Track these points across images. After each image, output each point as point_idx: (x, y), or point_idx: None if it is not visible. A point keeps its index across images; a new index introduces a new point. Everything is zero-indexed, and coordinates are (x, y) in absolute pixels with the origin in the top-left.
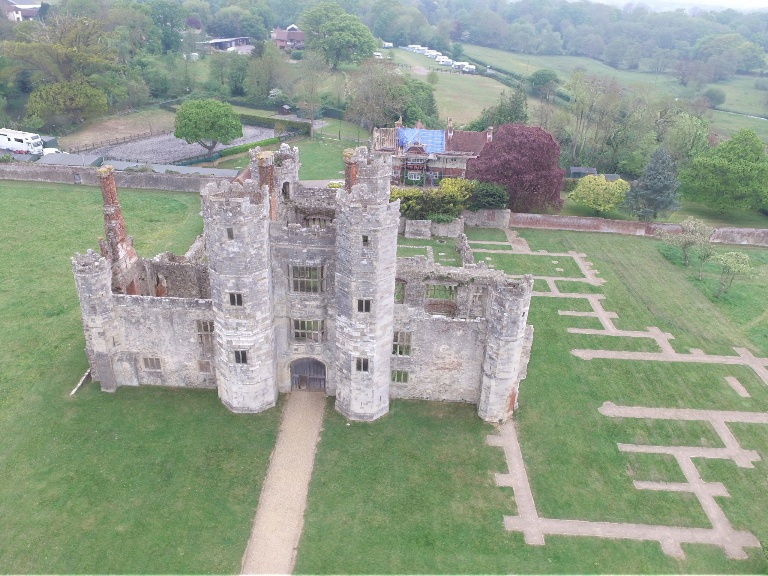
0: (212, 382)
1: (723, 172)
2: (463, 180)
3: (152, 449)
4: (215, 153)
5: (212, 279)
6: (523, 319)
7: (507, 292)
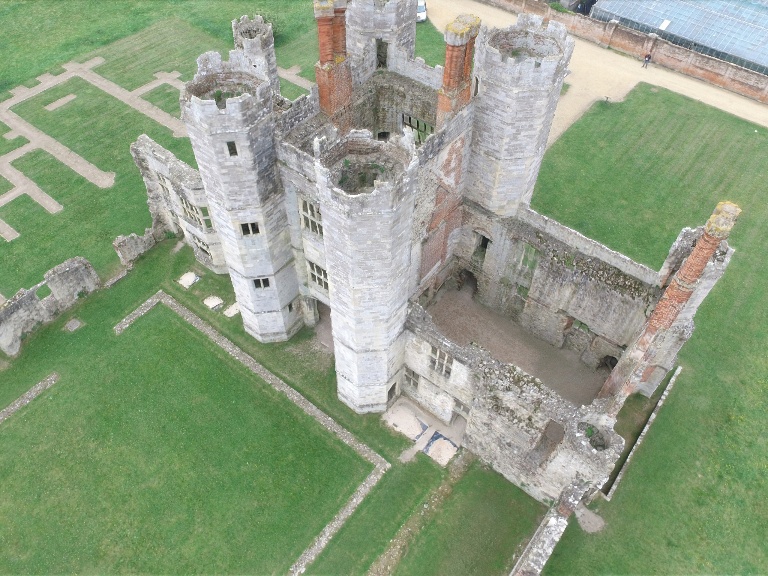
0: None
1: None
2: None
3: None
4: None
5: None
6: None
7: None
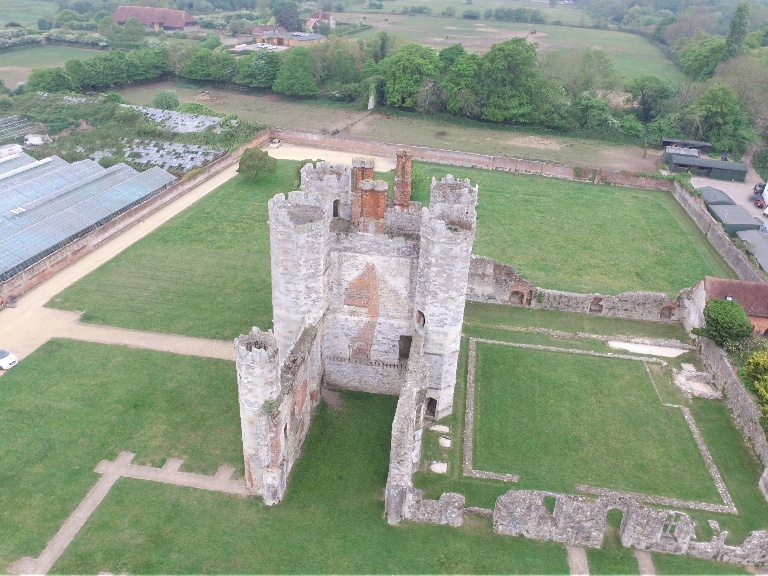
0: None
1: None
2: None
3: None
4: None
5: None
6: None
7: None
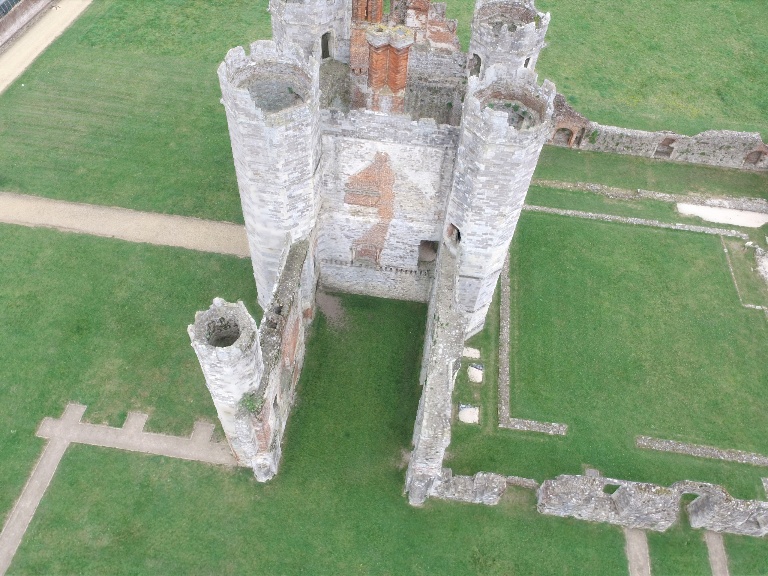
0: None
1: None
2: None
3: None
4: None
5: None
6: None
7: None
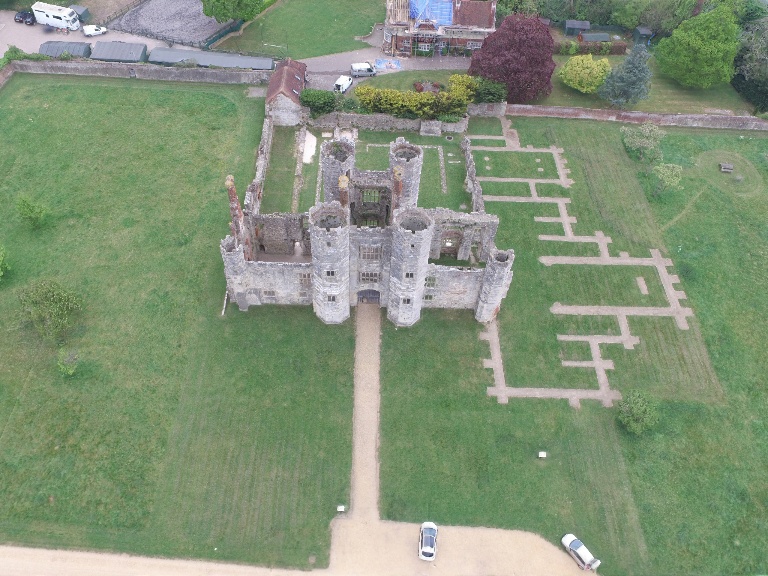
0: (308, 301)
1: (695, 51)
2: (469, 77)
3: (285, 353)
4: (238, 19)
5: (314, 261)
6: (507, 275)
7: (498, 265)
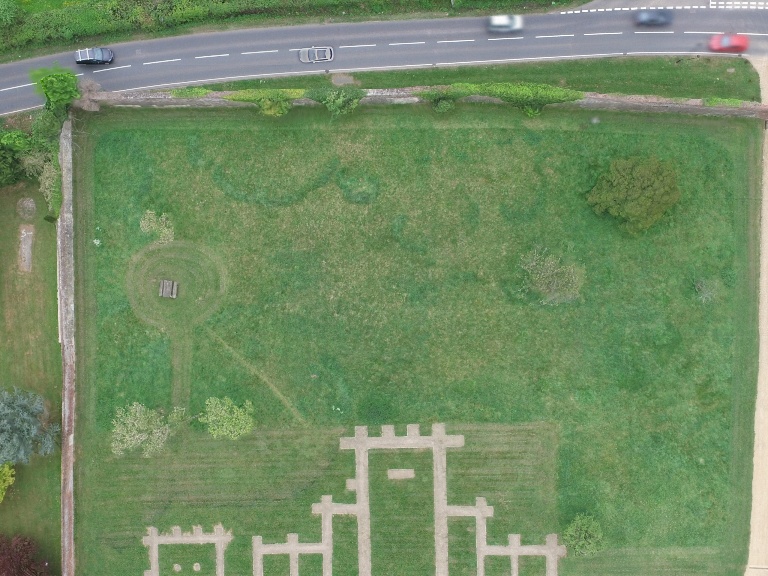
0: None
1: None
2: None
3: None
4: None
5: None
6: None
7: None
